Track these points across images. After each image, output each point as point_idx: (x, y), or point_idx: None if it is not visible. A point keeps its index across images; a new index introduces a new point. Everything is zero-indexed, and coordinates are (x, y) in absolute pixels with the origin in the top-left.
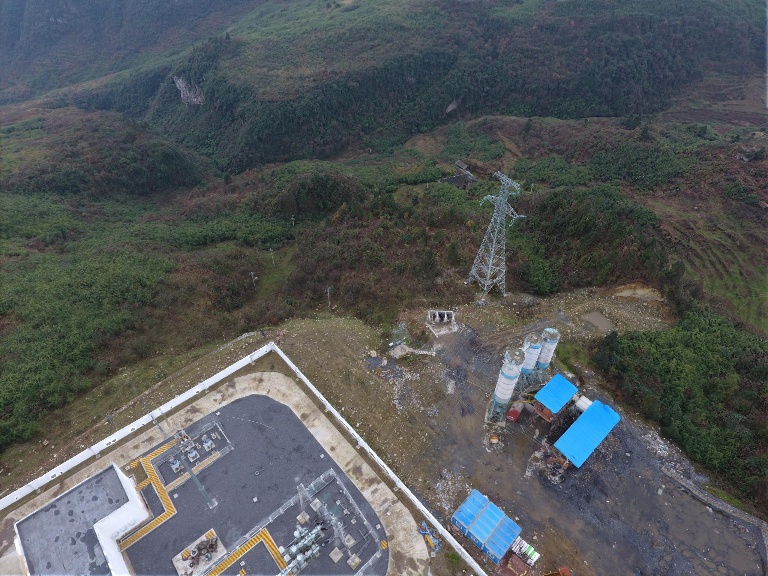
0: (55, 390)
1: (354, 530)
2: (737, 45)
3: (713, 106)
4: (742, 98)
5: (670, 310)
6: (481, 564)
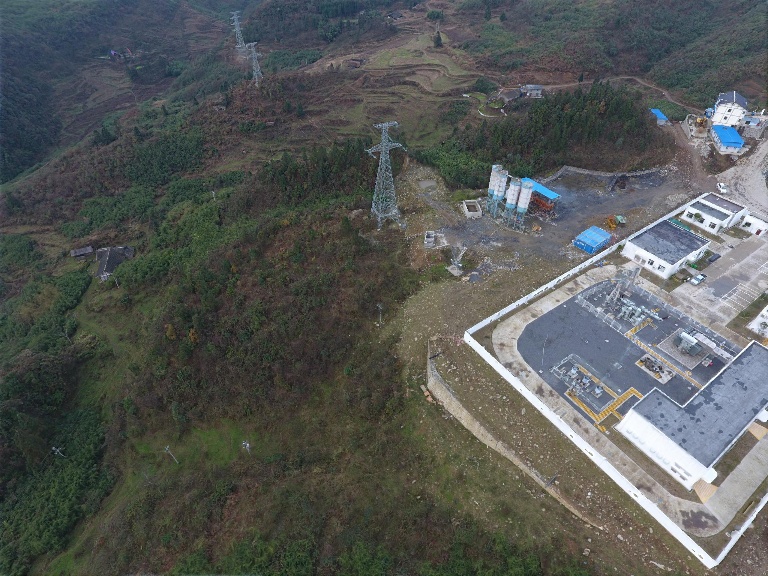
0: (522, 564)
1: None
2: (43, 51)
3: (87, 105)
4: (95, 90)
5: (416, 160)
6: None
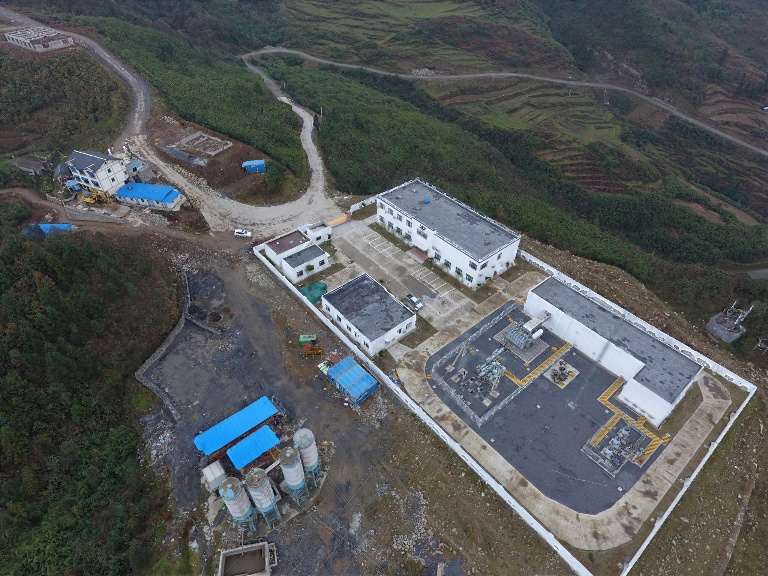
0: None
1: (453, 385)
2: None
3: None
4: None
5: None
6: (360, 365)
